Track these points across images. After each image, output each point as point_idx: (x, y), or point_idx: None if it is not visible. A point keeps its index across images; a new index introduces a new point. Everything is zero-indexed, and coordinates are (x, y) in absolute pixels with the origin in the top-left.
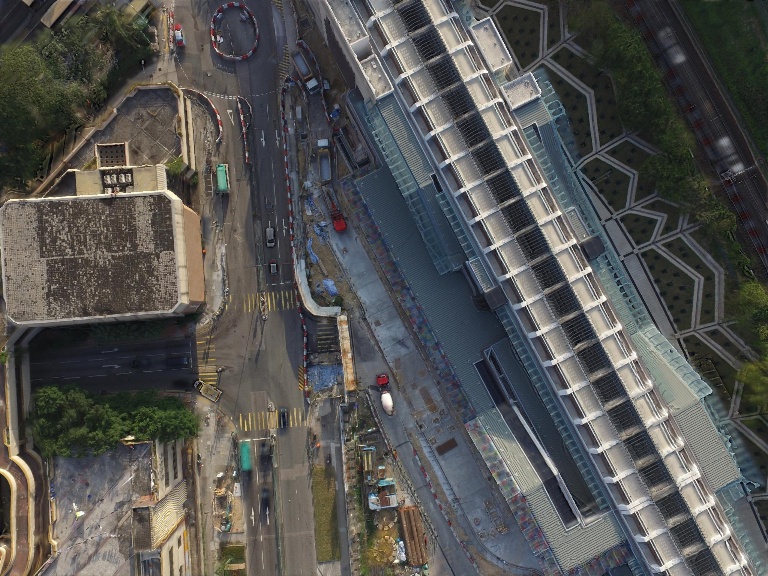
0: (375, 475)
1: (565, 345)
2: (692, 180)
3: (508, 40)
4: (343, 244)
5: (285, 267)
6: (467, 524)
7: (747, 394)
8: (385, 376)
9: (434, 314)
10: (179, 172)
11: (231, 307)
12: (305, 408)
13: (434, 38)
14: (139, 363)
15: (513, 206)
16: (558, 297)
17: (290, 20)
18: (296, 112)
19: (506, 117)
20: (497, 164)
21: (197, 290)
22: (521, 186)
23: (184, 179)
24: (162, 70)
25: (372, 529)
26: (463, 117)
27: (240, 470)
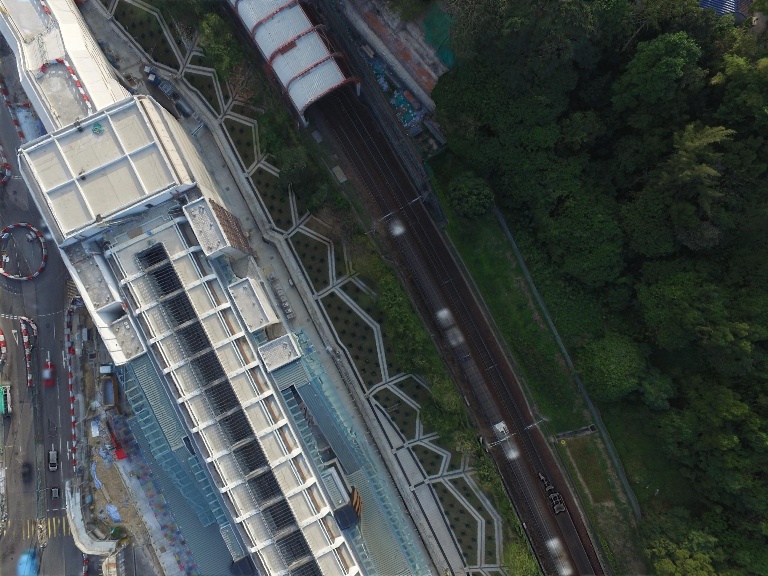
0: None
1: None
2: (457, 440)
3: (303, 264)
4: (130, 466)
5: None
6: None
7: None
8: None
9: (204, 559)
10: None
11: (9, 533)
12: None
13: (183, 305)
14: None
15: (258, 481)
16: (302, 575)
17: None
18: (82, 334)
19: (263, 379)
20: (245, 435)
21: None
22: (269, 458)
23: None
24: None
25: None
26: (213, 384)
27: None
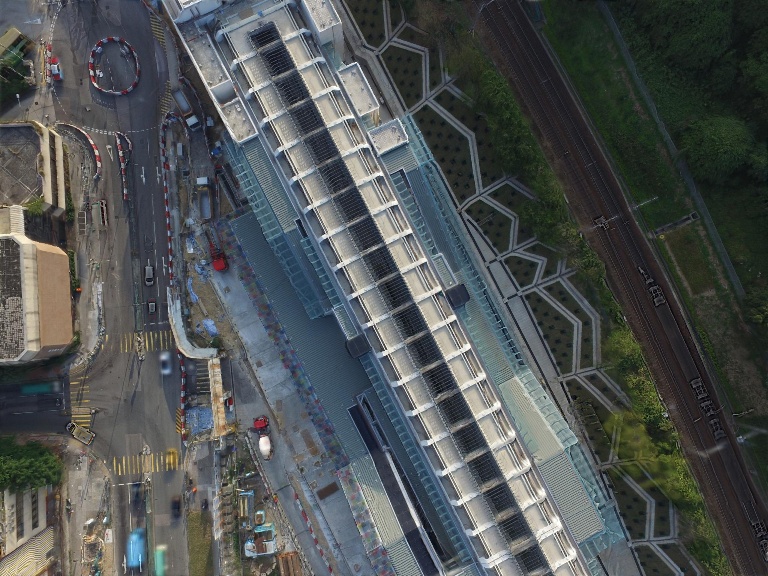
0: (251, 521)
1: (425, 395)
2: (562, 227)
3: (394, 80)
4: (225, 283)
5: (164, 306)
6: (347, 570)
7: (624, 439)
8: (263, 419)
9: (308, 358)
10: (40, 212)
11: (107, 347)
12: (182, 451)
13: (296, 83)
14: (9, 404)
15: (374, 254)
16: (419, 346)
17: (173, 56)
18: (177, 149)
19: (373, 162)
20: (359, 211)
21: (58, 333)
22: (383, 233)
23: (52, 218)
24: (39, 104)
25: (250, 575)
26: (326, 163)
27: (112, 516)
